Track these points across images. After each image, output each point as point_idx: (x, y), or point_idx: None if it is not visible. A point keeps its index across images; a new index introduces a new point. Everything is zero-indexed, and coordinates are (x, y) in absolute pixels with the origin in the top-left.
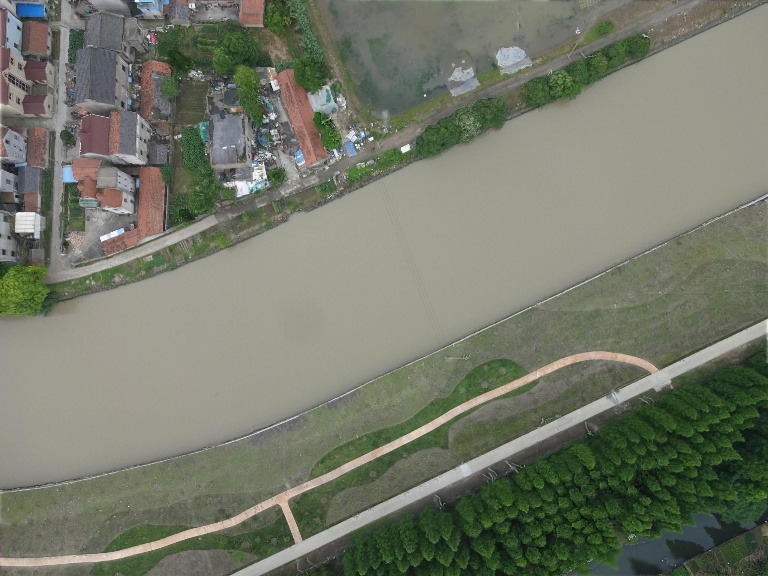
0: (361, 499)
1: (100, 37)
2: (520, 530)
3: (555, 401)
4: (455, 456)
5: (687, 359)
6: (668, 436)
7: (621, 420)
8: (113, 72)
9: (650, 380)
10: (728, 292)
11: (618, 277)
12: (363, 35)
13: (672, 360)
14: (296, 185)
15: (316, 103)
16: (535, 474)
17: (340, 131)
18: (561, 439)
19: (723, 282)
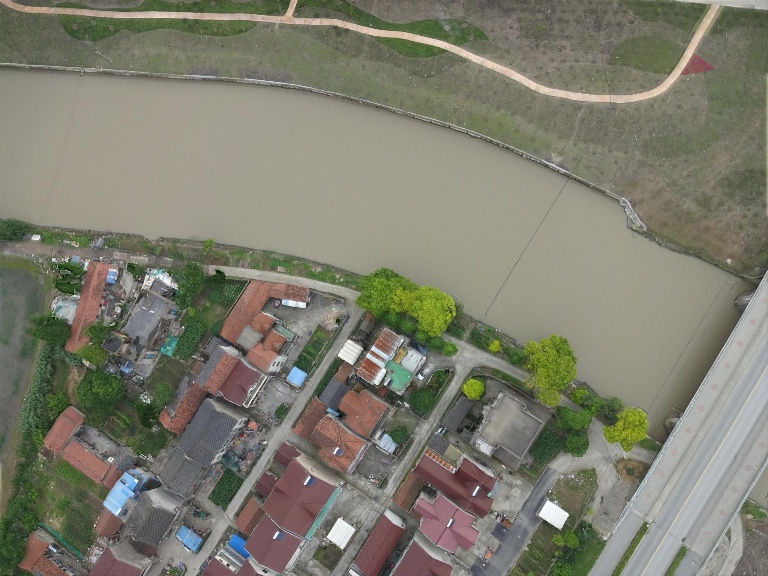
0: None
1: (182, 466)
2: None
3: None
4: None
5: None
6: None
7: None
8: (190, 427)
9: None
10: None
11: None
12: (8, 351)
13: None
14: (133, 259)
15: (70, 311)
16: None
17: (72, 281)
18: None
19: None
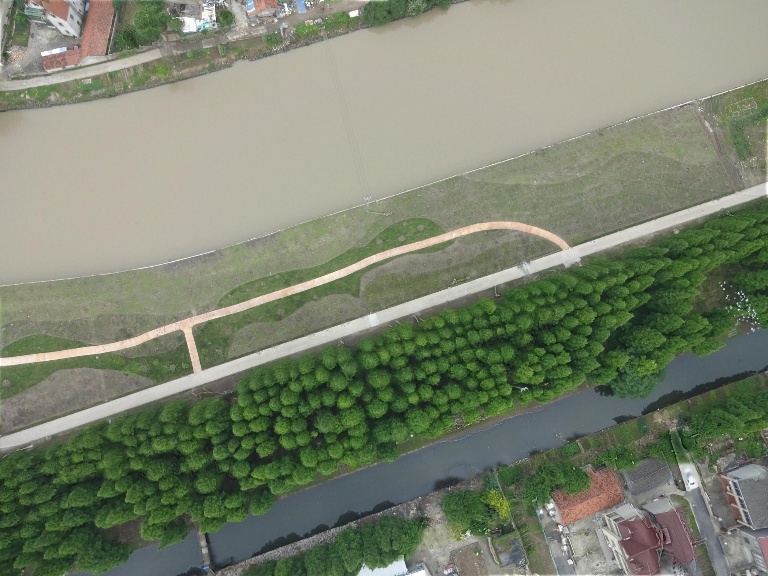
0: (266, 336)
1: None
2: (416, 367)
3: (468, 264)
4: (365, 305)
5: (597, 240)
6: (568, 294)
7: (528, 284)
8: None
9: (561, 256)
10: (641, 181)
11: (541, 158)
12: None
13: (583, 239)
14: (244, 32)
15: None
16: (437, 317)
17: None
18: (470, 301)
19: (637, 172)
